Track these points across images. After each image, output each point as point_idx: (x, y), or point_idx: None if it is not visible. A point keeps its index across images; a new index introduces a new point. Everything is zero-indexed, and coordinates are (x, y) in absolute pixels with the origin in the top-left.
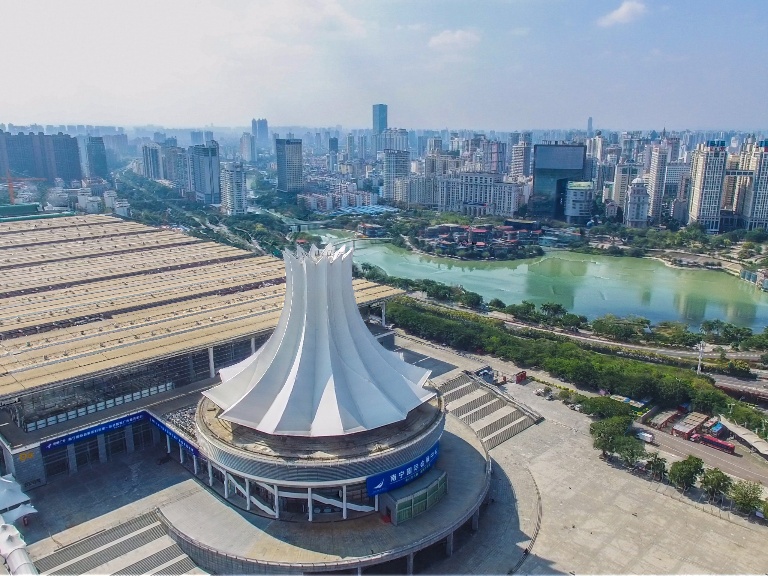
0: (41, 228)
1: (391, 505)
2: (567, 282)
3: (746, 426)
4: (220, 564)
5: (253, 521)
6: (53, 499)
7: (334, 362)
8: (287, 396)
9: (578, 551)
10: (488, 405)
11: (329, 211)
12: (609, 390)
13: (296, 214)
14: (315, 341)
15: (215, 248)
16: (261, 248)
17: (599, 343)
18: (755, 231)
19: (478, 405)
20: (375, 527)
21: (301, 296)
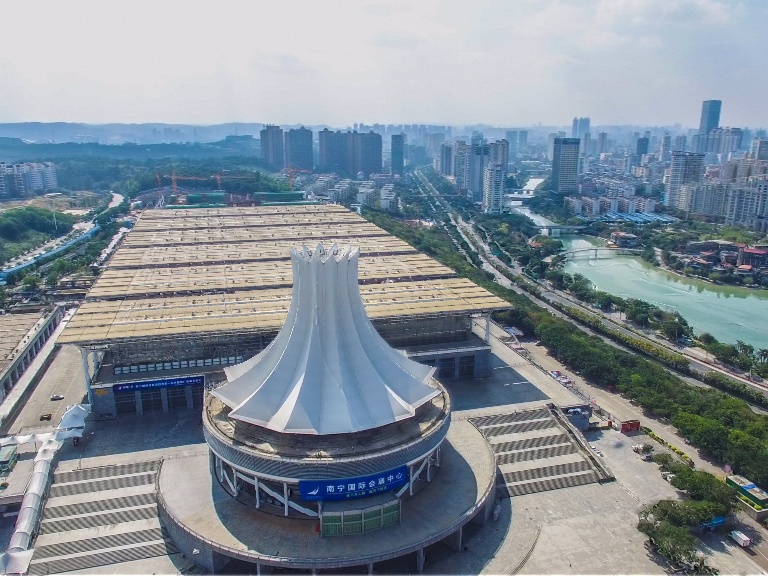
0: (280, 213)
1: None
2: None
3: None
4: (167, 520)
5: (215, 492)
6: (109, 431)
7: (313, 361)
8: (261, 385)
9: None
10: (552, 447)
11: (594, 216)
12: (732, 467)
13: (557, 217)
14: (304, 337)
15: (389, 242)
16: (490, 248)
17: None
18: None
19: (539, 444)
20: (302, 532)
21: None
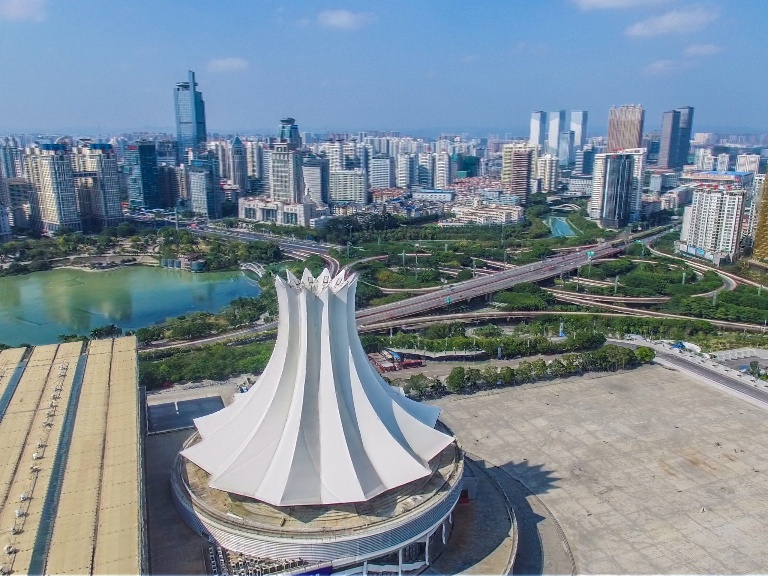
0: None
1: (469, 484)
2: (26, 310)
3: (408, 347)
4: None
5: None
6: None
7: None
8: (390, 438)
9: (504, 449)
10: None
11: None
12: None
13: None
14: None
15: None
16: None
17: (194, 345)
18: (123, 226)
19: None
20: (473, 509)
21: (332, 333)
